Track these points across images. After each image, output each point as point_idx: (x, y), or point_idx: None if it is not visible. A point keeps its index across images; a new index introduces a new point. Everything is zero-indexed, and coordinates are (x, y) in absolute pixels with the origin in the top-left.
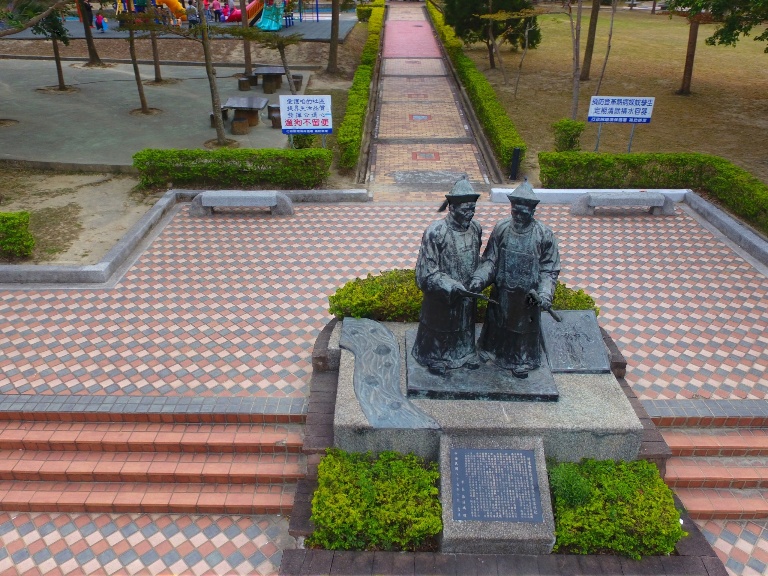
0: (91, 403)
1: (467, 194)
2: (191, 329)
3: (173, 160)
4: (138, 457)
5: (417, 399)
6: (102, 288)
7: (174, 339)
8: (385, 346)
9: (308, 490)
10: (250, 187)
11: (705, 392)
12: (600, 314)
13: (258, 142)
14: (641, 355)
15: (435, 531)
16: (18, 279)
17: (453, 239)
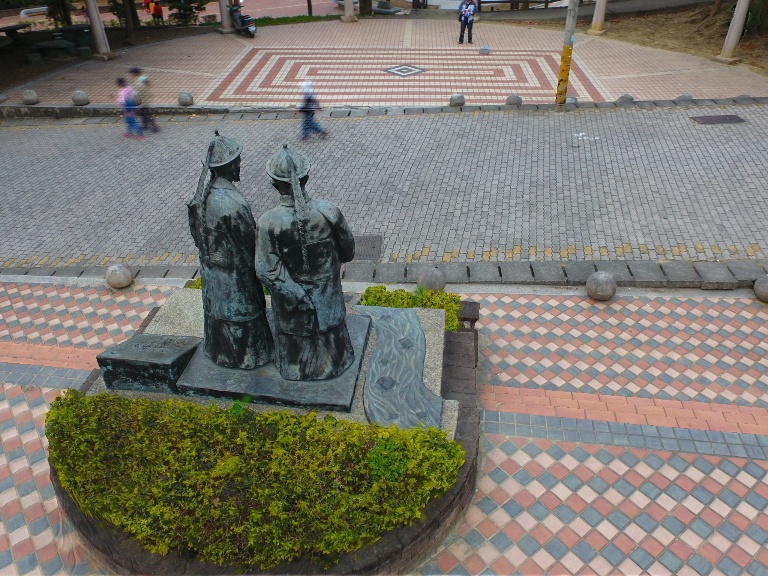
0: (759, 446)
1: None
2: None
3: None
4: None
5: None
6: None
7: None
8: (384, 379)
9: None
10: None
11: (12, 393)
12: None
13: None
14: (5, 458)
15: None
16: None
17: None
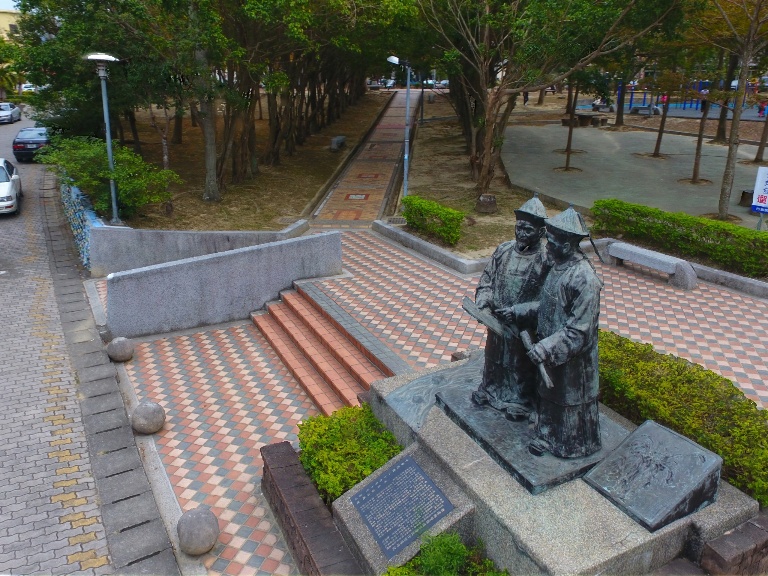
0: (347, 321)
1: (519, 210)
2: (457, 318)
3: (627, 212)
4: (334, 363)
5: (439, 408)
6: (459, 276)
7: (438, 317)
8: None
9: None
10: (689, 258)
11: None
12: None
13: (766, 226)
14: None
15: (328, 489)
16: (430, 254)
17: (508, 258)
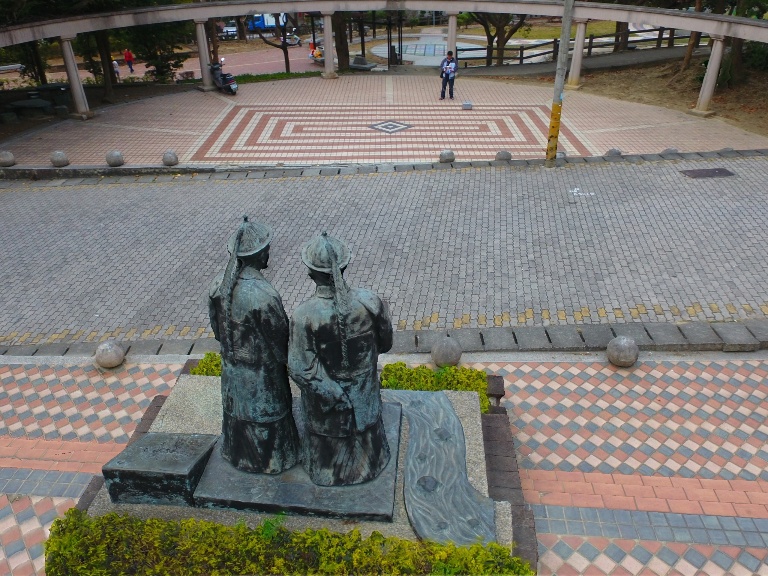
0: None
1: None
2: None
3: None
4: None
5: None
6: None
7: None
8: (426, 480)
9: None
10: None
11: None
12: None
13: None
14: None
15: None
16: None
17: None
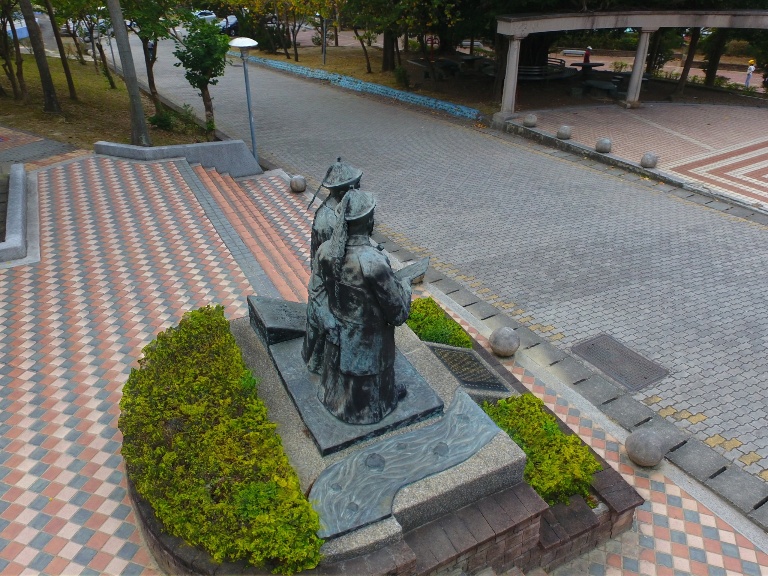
0: None
1: None
2: None
3: None
4: None
5: None
6: None
7: None
8: (373, 456)
9: (550, 531)
10: None
11: None
12: (114, 364)
13: None
14: None
15: None
16: None
17: None
